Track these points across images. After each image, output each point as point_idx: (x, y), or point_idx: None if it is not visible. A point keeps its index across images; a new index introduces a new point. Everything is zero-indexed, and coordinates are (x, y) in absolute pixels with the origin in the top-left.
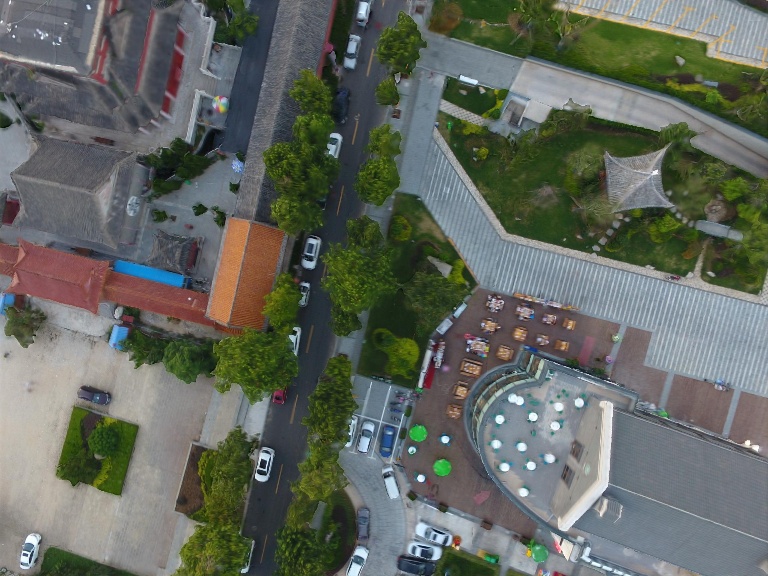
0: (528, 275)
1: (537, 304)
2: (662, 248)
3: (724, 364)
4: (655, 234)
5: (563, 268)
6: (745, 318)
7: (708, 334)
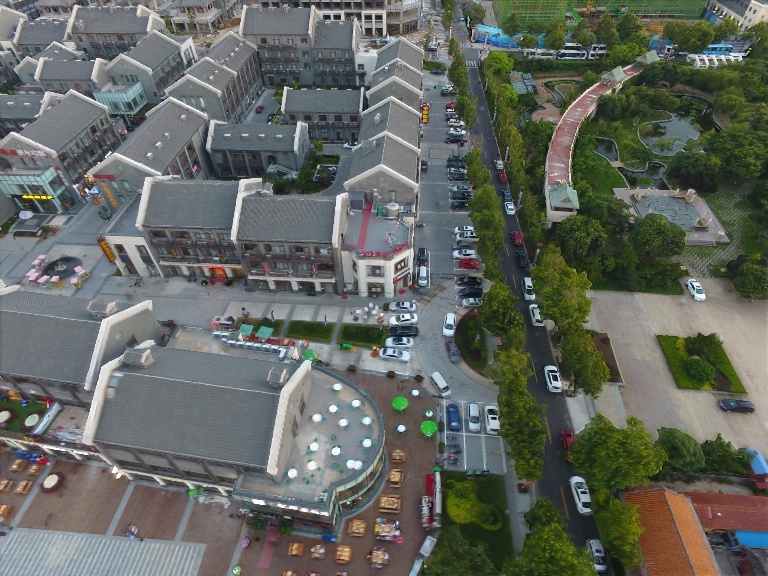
0: None
1: None
2: None
3: (117, 564)
4: None
5: None
6: None
7: None
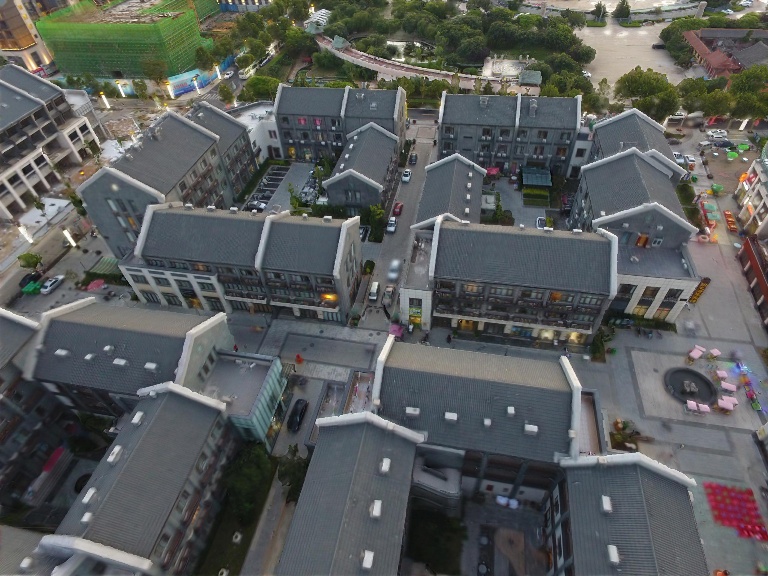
0: None
1: None
2: None
3: None
4: None
5: None
6: None
7: None
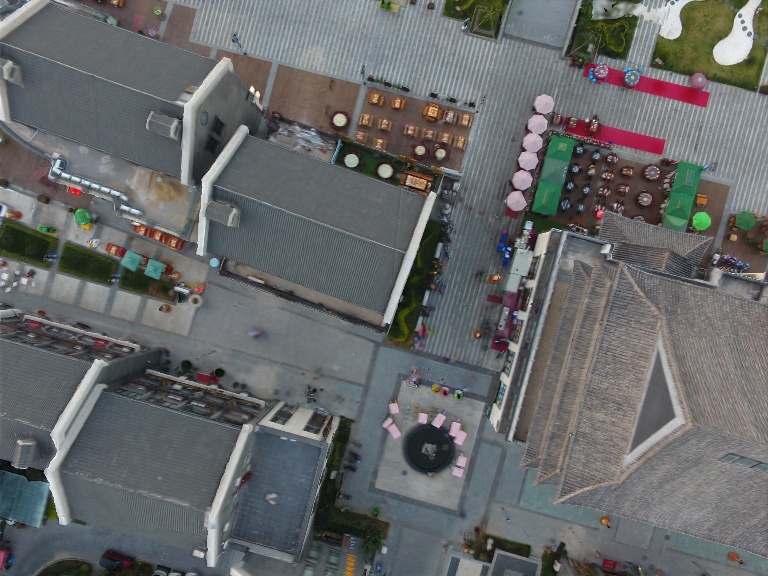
0: None
1: None
2: None
3: (263, 38)
4: None
5: None
6: None
7: (248, 10)
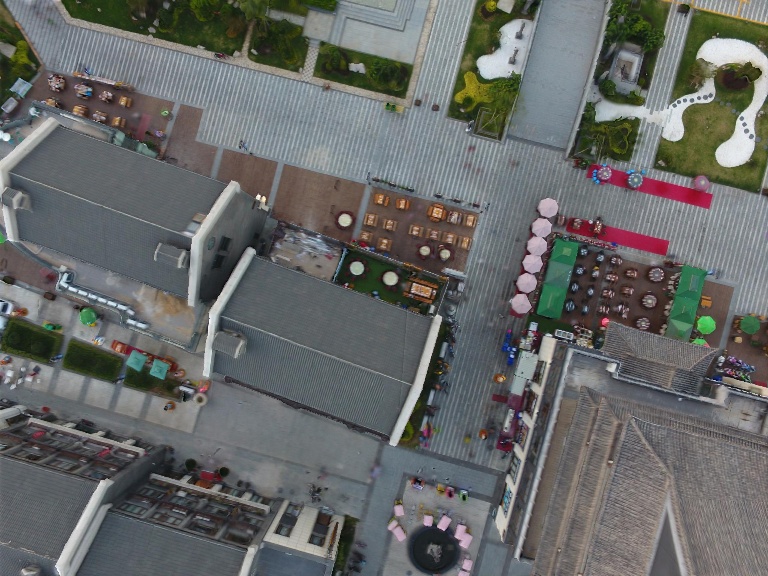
0: (90, 57)
1: (98, 84)
2: (209, 28)
3: (269, 138)
4: (198, 12)
5: (122, 50)
6: (288, 95)
7: (254, 110)
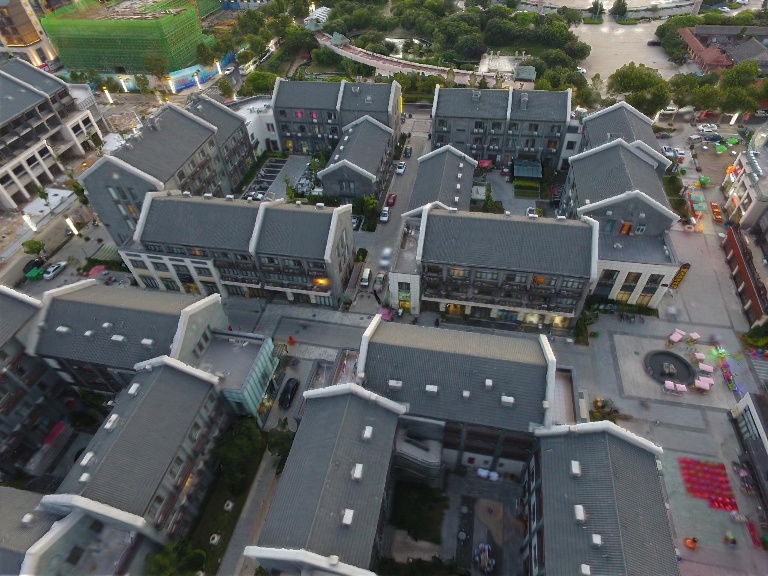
0: None
1: None
2: None
3: None
4: None
5: None
6: None
7: None
